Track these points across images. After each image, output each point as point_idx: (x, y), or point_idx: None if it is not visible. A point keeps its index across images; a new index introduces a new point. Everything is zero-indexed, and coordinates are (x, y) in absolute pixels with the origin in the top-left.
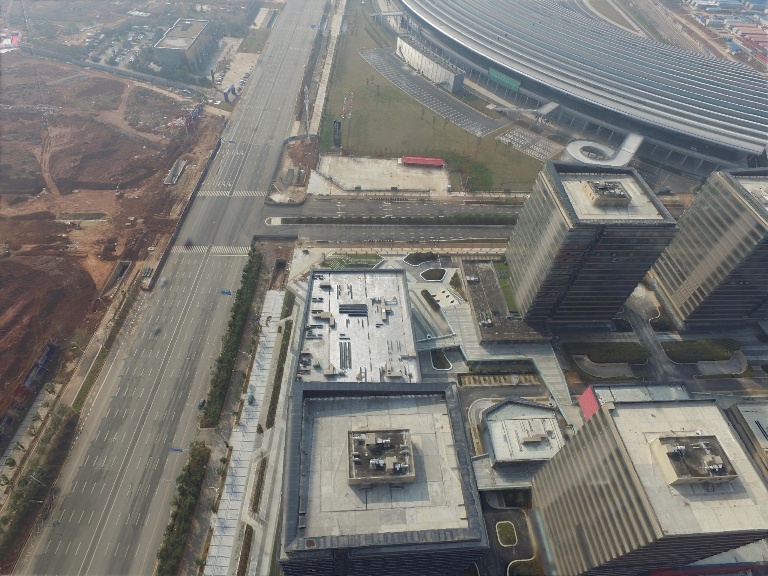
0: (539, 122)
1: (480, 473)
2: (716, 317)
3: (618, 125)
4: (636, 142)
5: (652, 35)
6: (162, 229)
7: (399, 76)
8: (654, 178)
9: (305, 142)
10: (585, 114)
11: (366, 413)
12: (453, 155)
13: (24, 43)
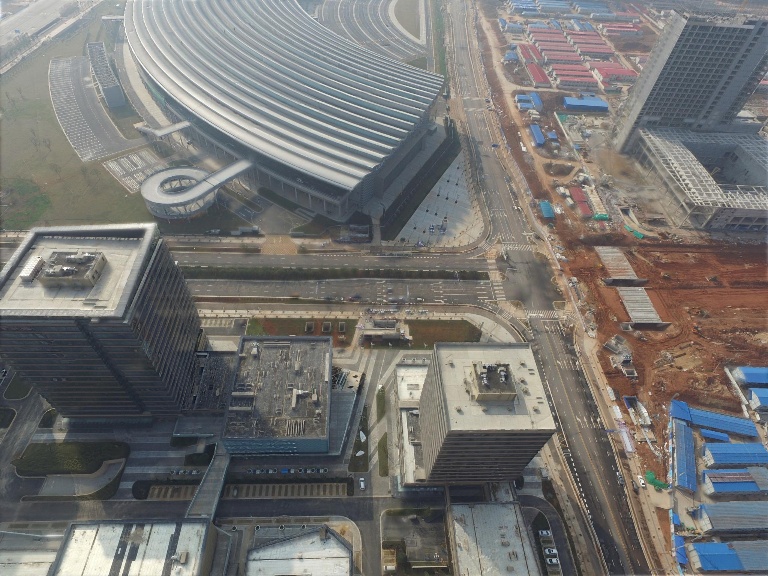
0: (180, 144)
1: None
2: (103, 413)
3: (236, 150)
4: (235, 171)
5: (433, 42)
6: None
7: (67, 88)
8: (256, 215)
9: None
10: (210, 136)
11: None
12: (24, 184)
13: None
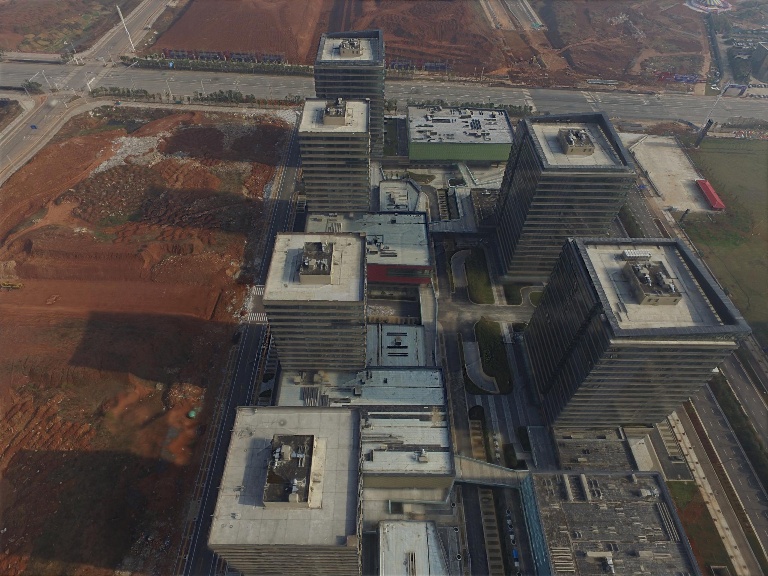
0: None
1: (376, 182)
2: None
3: None
4: None
5: None
6: (541, 84)
7: None
8: None
9: (689, 130)
10: None
11: (371, 49)
12: (746, 220)
13: (717, 12)
